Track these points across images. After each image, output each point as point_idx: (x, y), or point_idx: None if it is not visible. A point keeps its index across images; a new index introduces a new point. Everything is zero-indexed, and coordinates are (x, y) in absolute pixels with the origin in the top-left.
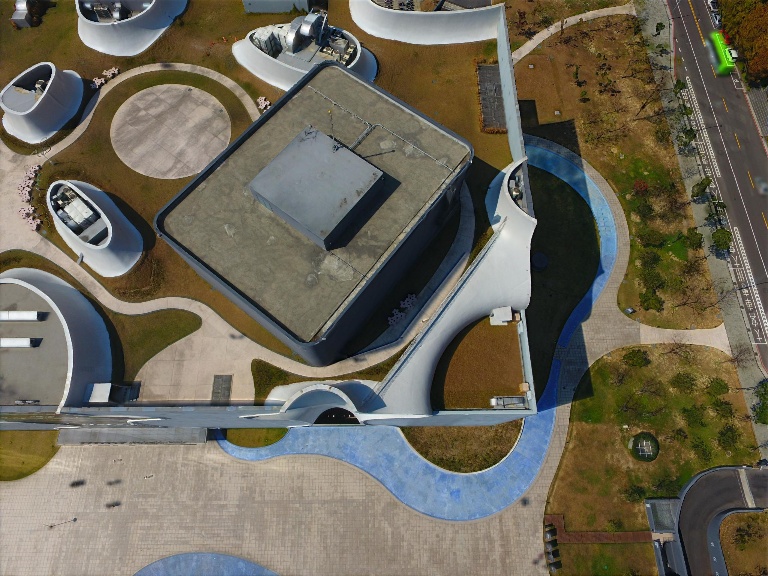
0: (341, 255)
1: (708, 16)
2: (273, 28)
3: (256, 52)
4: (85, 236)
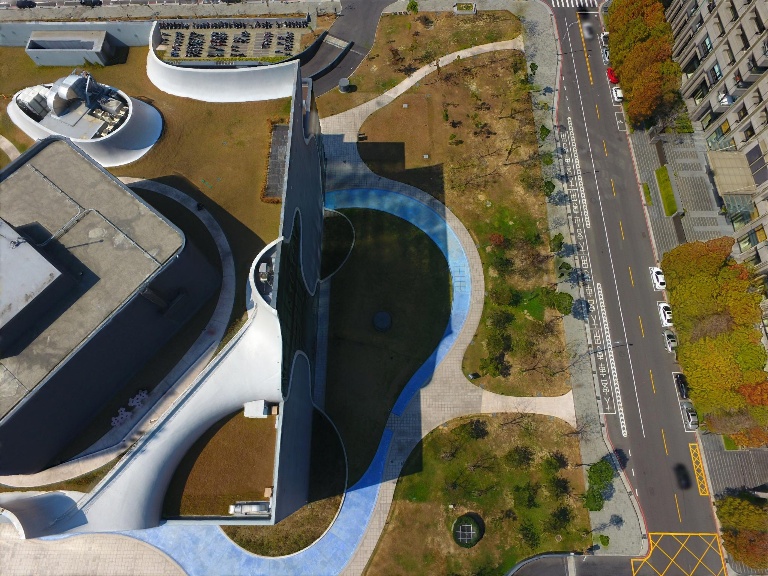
0: (10, 365)
1: (600, 51)
2: (40, 88)
3: (20, 115)
4: None
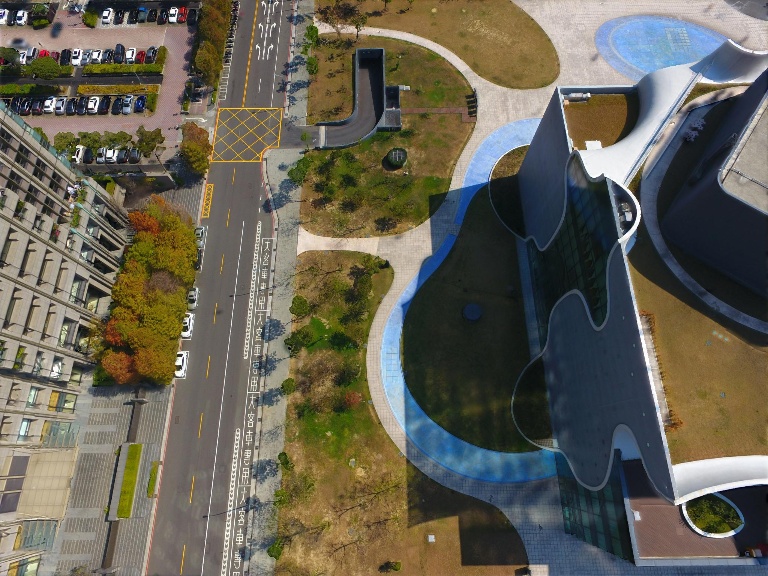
0: None
1: None
2: None
3: None
4: None
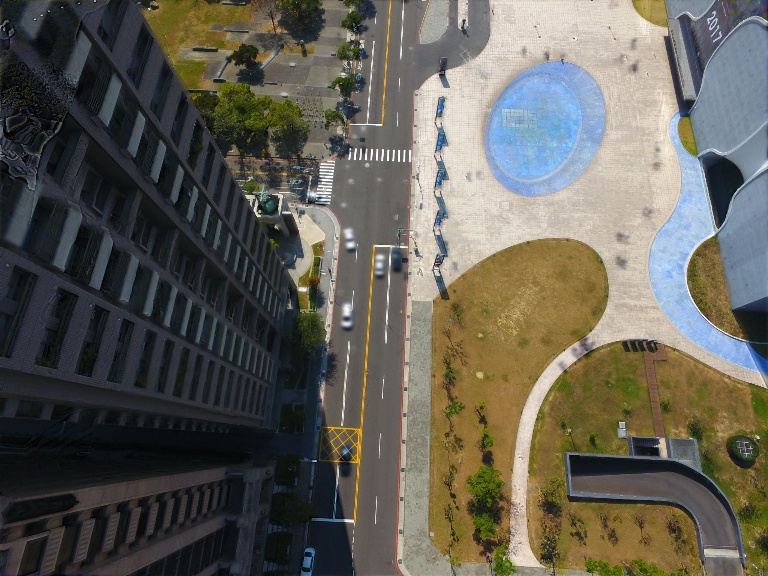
0: None
1: None
2: None
3: None
4: None
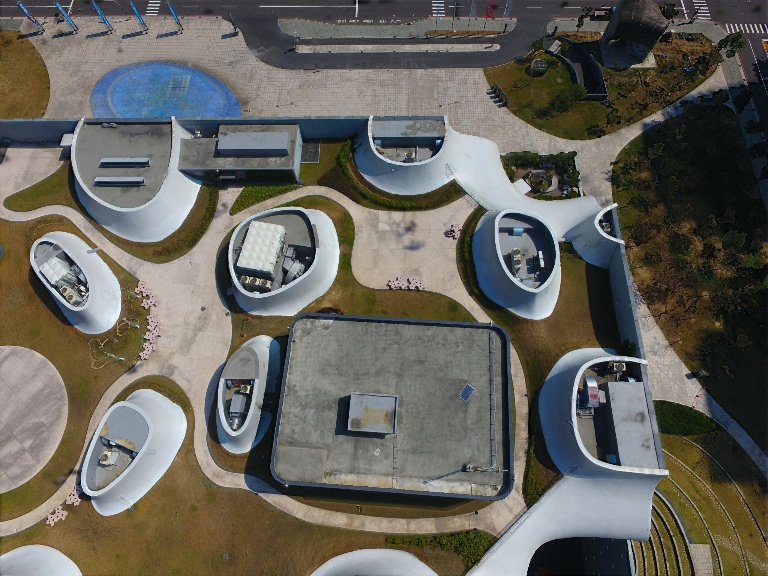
0: None
1: None
2: None
3: None
4: (56, 250)
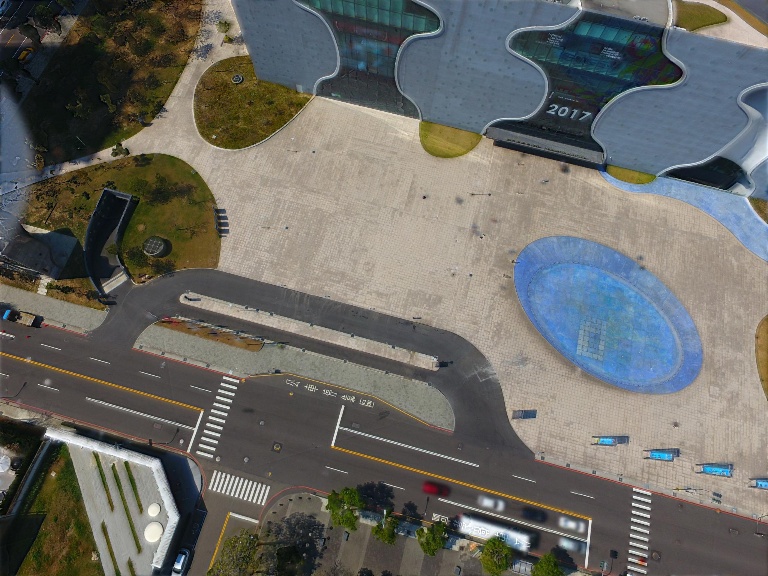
0: None
1: None
2: None
3: None
4: None
